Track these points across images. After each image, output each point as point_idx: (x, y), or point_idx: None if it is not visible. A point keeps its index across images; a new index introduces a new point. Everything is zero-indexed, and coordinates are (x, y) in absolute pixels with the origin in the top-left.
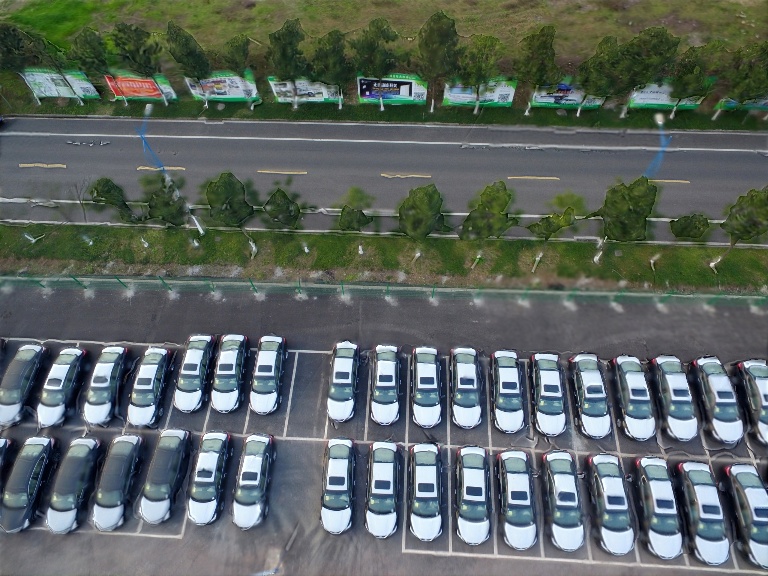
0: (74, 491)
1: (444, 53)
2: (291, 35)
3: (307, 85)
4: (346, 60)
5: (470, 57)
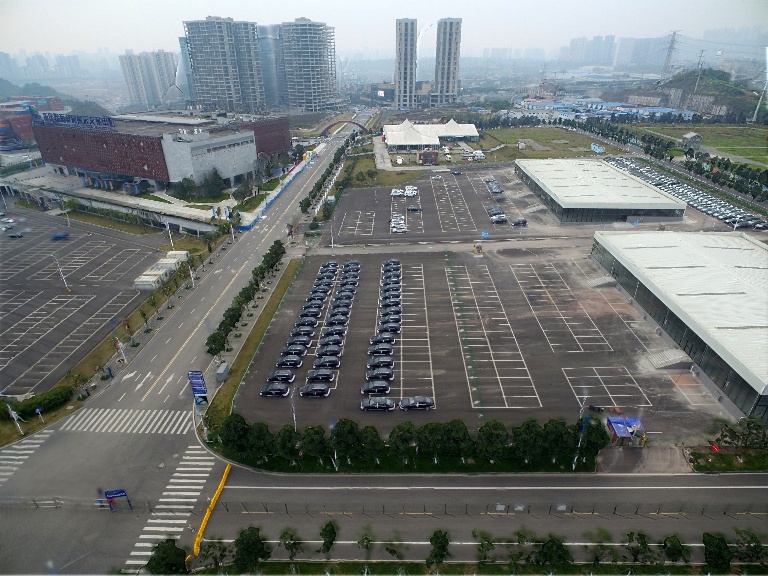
0: (644, 176)
1: (765, 177)
2: (744, 166)
3: (740, 178)
4: (749, 174)
5: (767, 179)
